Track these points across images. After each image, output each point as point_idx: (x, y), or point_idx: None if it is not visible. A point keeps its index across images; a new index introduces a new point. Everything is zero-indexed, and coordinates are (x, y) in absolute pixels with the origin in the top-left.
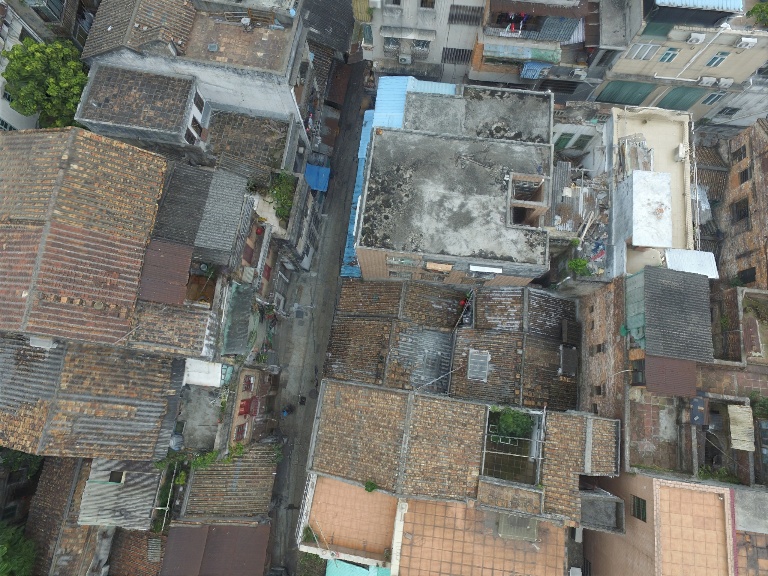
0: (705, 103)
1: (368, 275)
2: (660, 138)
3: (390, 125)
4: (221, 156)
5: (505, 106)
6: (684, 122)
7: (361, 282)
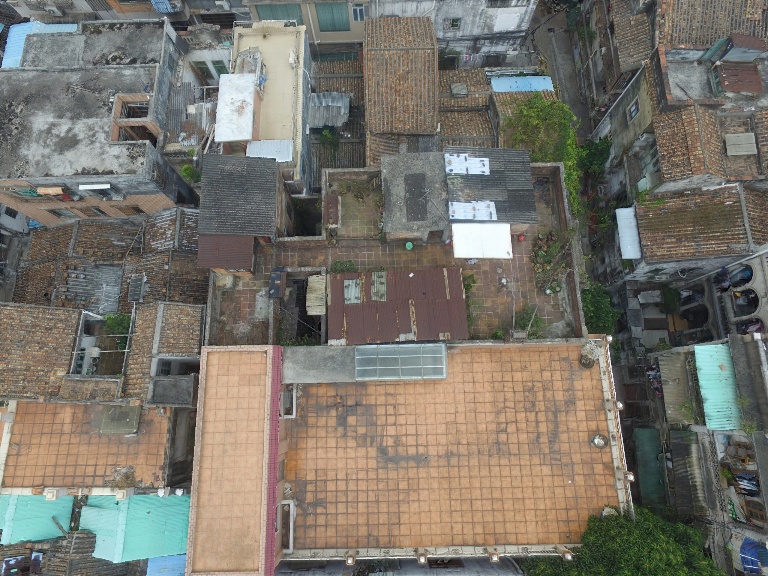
0: (357, 20)
1: (42, 221)
2: (280, 49)
3: None
4: None
5: (122, 36)
6: (300, 32)
7: (45, 230)
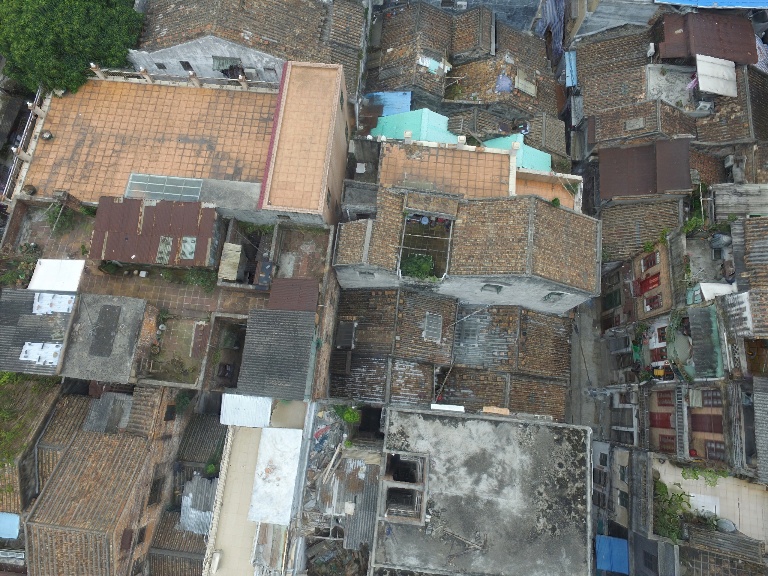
0: None
1: None
2: None
3: None
4: (761, 557)
5: None
6: None
7: None
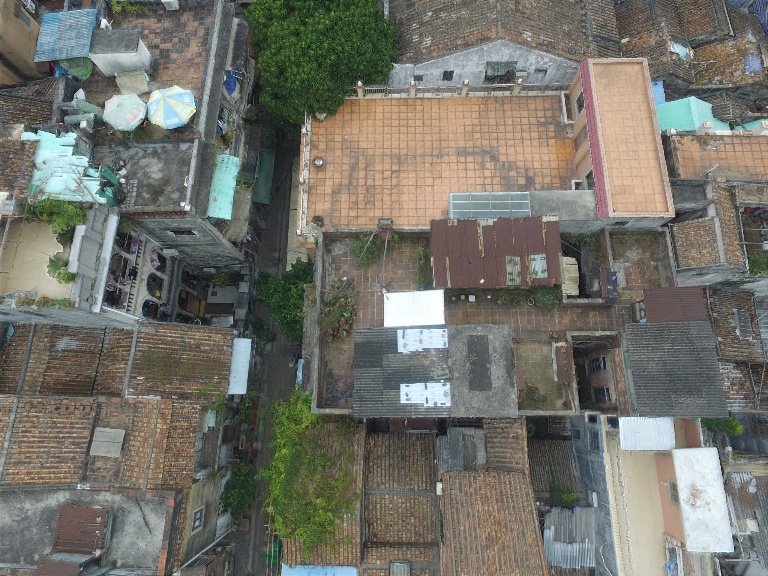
0: None
1: None
2: None
3: None
4: None
5: None
6: None
7: None
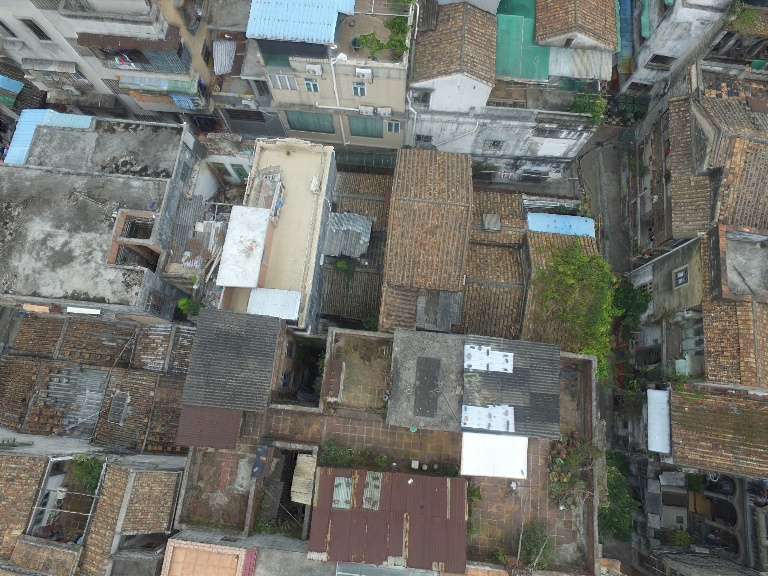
0: (391, 131)
1: (32, 312)
2: (303, 170)
3: (19, 160)
4: None
5: (137, 139)
6: (326, 153)
7: (35, 319)
